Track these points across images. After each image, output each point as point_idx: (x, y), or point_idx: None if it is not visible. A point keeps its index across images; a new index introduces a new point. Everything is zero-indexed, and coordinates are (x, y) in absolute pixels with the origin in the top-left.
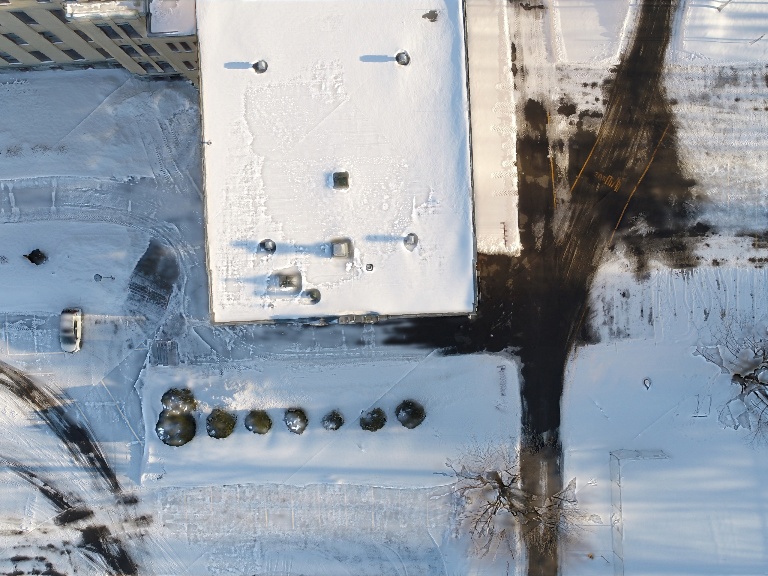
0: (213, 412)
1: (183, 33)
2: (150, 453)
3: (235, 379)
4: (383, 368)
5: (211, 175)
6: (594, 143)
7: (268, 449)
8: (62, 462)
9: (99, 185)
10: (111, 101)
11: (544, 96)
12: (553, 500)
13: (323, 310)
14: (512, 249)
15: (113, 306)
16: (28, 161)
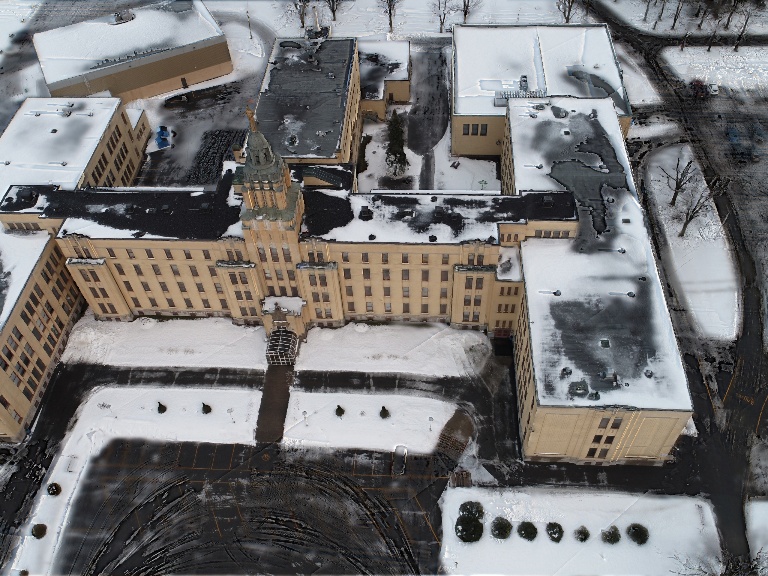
0: (497, 518)
1: (515, 280)
2: (446, 550)
3: (512, 498)
4: (615, 499)
5: (534, 336)
6: (731, 378)
7: (534, 553)
8: (380, 553)
9: (426, 378)
10: (437, 337)
11: (695, 352)
12: (762, 572)
13: (603, 403)
14: (692, 432)
15: (428, 448)
16: (384, 363)
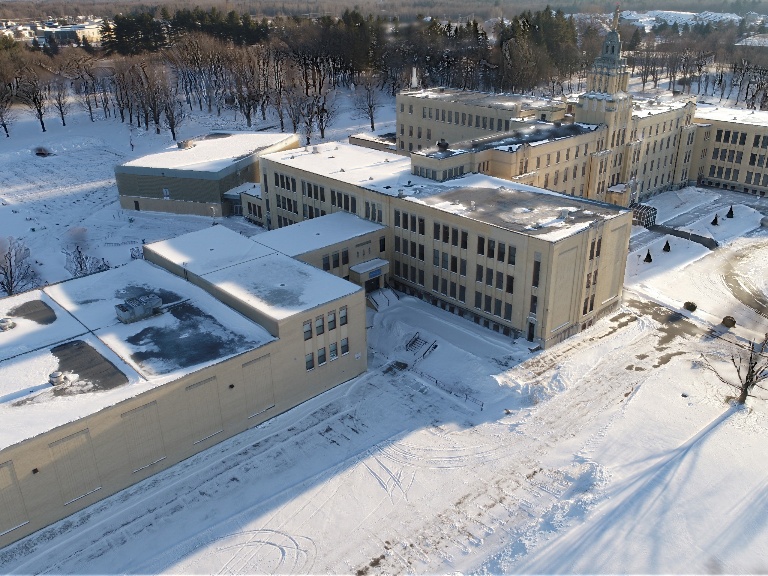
0: None
1: None
2: None
3: None
4: None
5: None
6: None
7: None
8: None
9: None
10: None
11: None
12: None
13: None
14: None
15: None
16: None
